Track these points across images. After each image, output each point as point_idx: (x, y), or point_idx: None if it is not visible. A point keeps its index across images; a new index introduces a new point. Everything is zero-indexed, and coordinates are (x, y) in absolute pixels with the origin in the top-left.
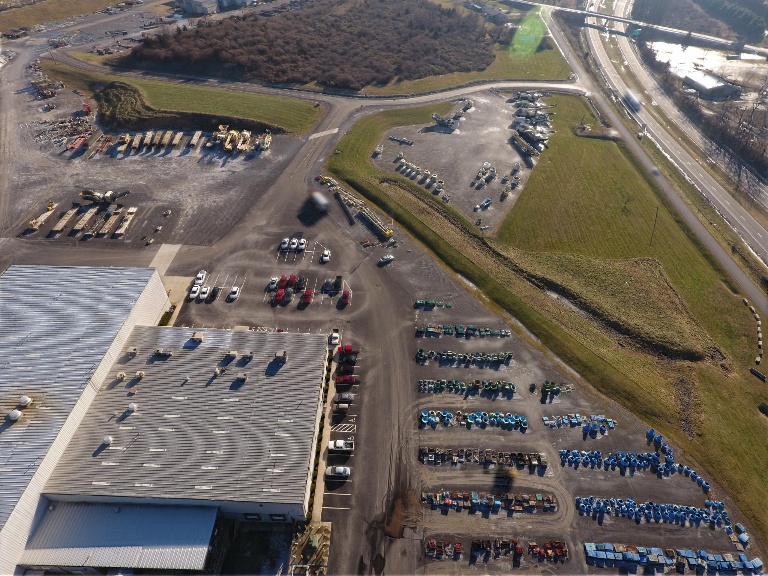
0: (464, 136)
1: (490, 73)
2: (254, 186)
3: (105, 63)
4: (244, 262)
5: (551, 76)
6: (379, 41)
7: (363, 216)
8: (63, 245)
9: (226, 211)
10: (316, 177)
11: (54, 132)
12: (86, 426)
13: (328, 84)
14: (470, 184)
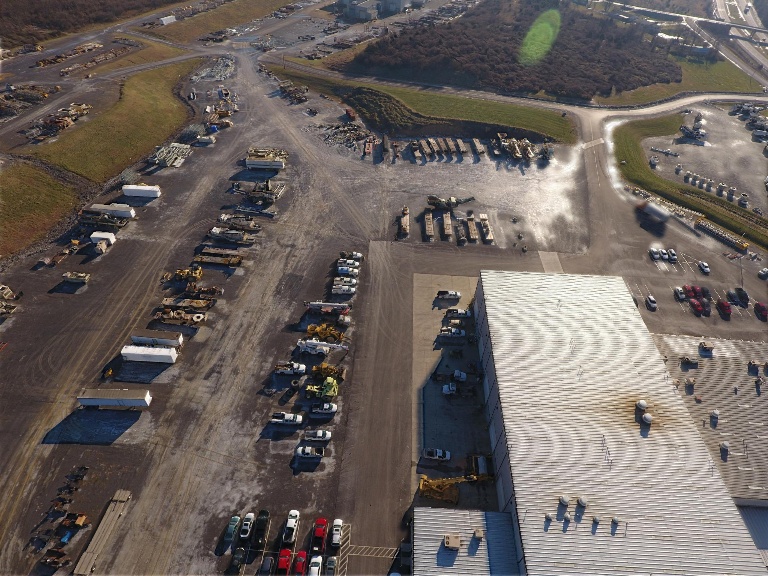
0: (718, 148)
1: (688, 85)
2: (572, 195)
3: (332, 68)
4: (631, 271)
5: (746, 89)
6: (573, 51)
7: (702, 228)
8: (446, 250)
9: (568, 219)
10: (625, 187)
11: (338, 136)
12: None
13: (560, 93)
14: (767, 198)
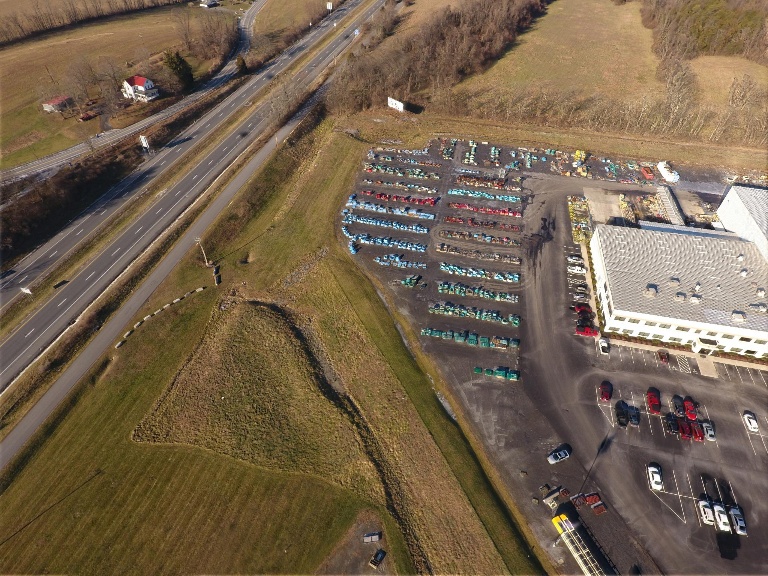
0: None
1: None
2: None
3: None
4: None
5: None
6: None
7: None
8: None
9: None
10: None
11: None
12: (765, 269)
13: None
14: None
